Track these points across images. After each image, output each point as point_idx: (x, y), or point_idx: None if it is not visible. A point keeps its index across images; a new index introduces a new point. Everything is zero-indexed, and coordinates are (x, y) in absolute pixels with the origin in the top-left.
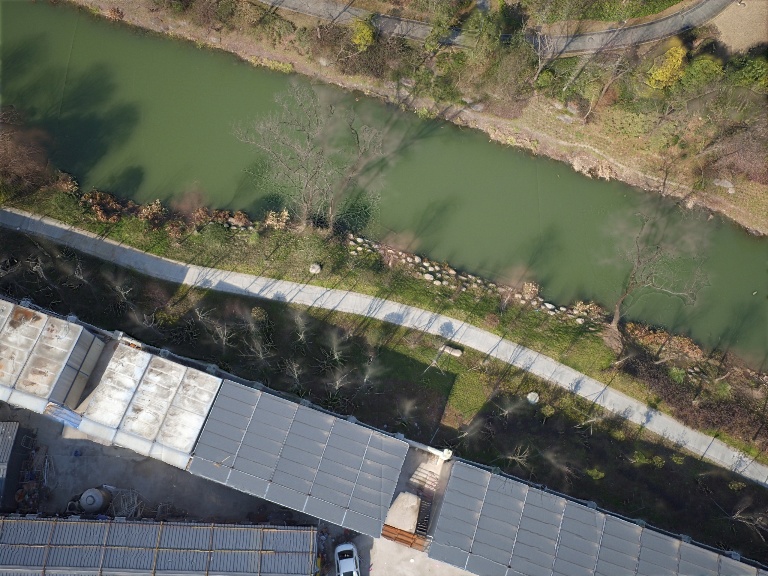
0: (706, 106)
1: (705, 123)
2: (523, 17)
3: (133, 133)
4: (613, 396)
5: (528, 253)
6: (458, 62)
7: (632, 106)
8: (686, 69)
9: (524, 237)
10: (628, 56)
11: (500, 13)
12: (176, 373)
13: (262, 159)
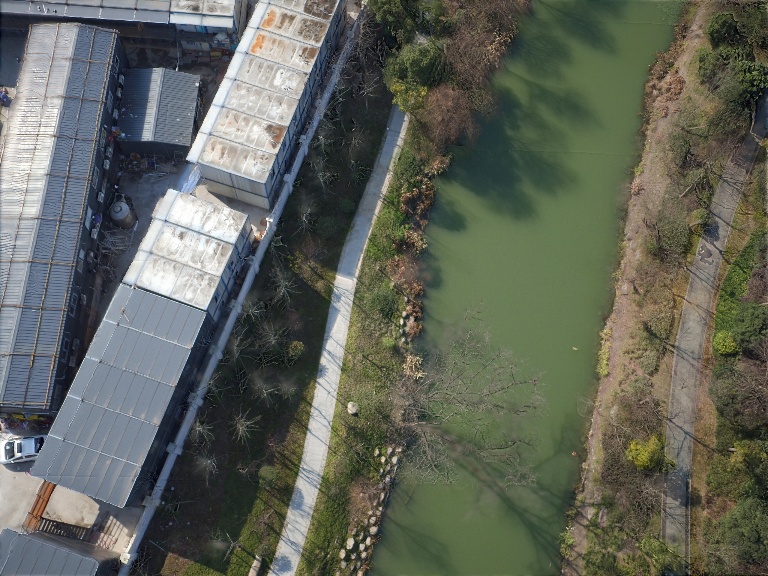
0: None
1: None
2: None
3: (502, 217)
4: None
5: None
6: None
7: None
8: None
9: None
10: None
11: None
12: (215, 267)
13: (486, 347)
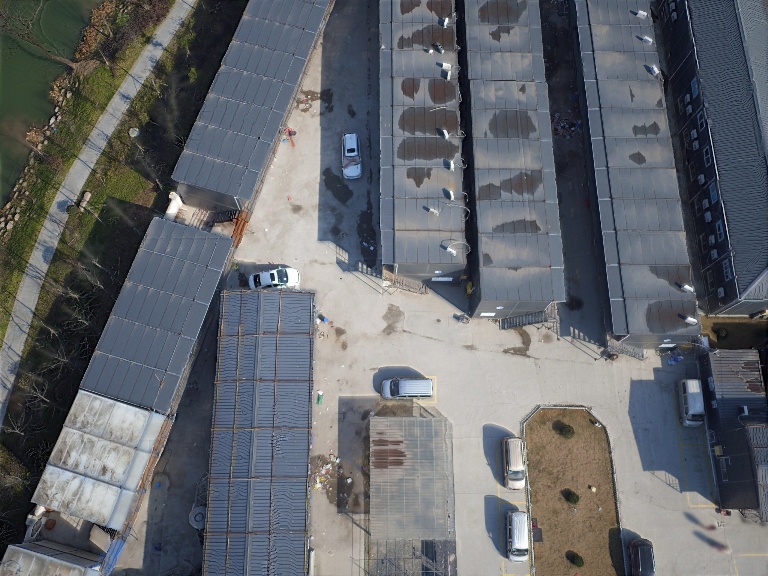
0: None
1: None
2: None
3: None
4: (138, 70)
5: None
6: None
7: None
8: None
9: None
10: None
11: None
12: (69, 437)
13: None
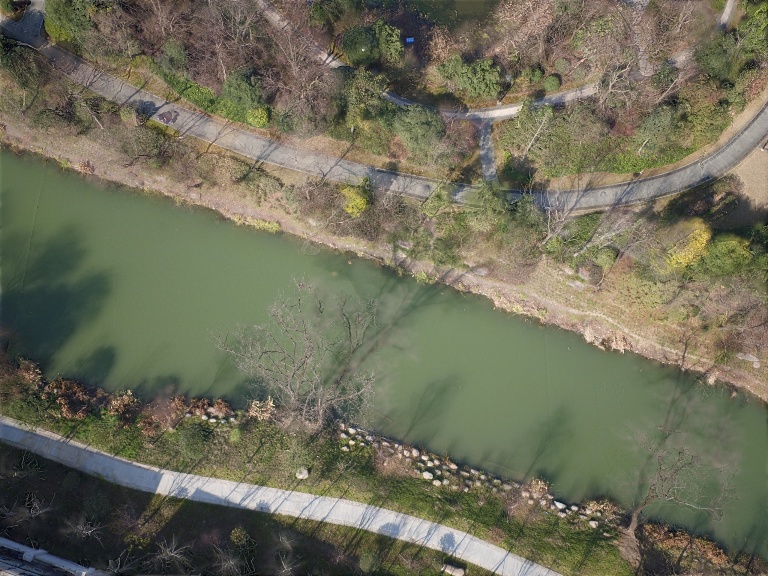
0: (729, 274)
1: (728, 292)
2: (530, 170)
3: (103, 307)
4: None
5: (536, 441)
6: (460, 224)
7: (649, 274)
8: (710, 250)
9: (532, 422)
10: (644, 213)
11: (505, 166)
12: None
13: (245, 335)
